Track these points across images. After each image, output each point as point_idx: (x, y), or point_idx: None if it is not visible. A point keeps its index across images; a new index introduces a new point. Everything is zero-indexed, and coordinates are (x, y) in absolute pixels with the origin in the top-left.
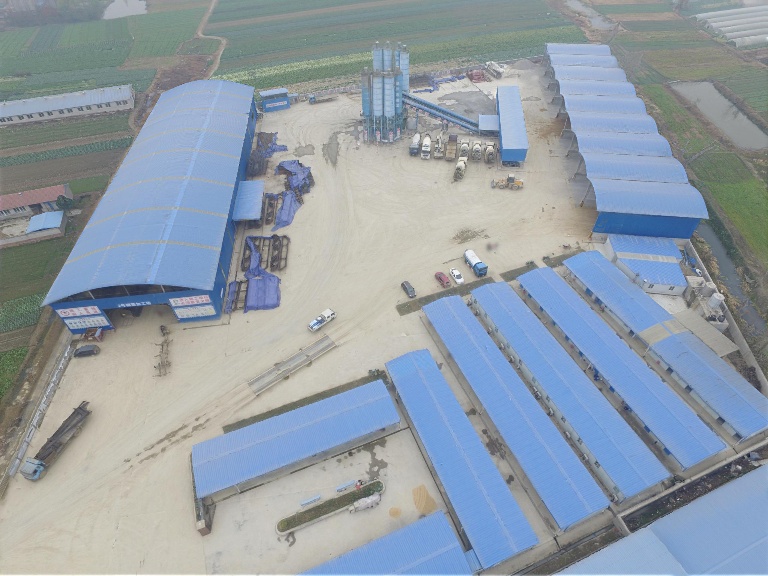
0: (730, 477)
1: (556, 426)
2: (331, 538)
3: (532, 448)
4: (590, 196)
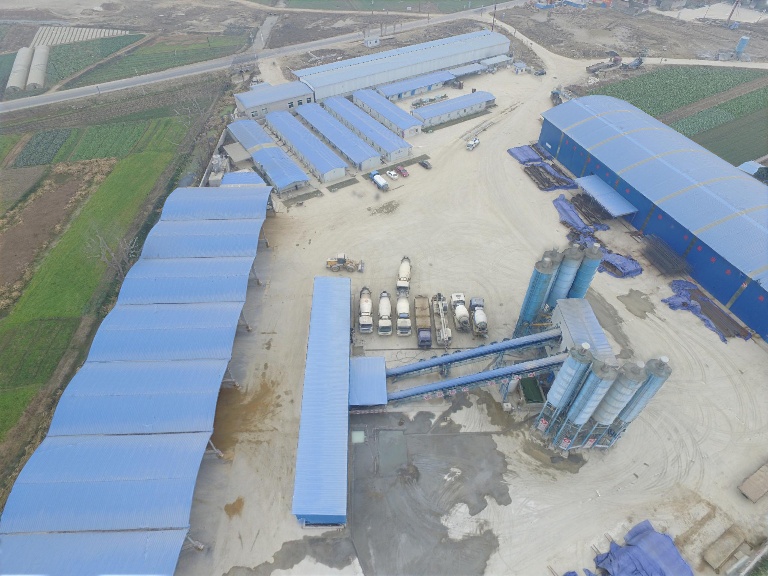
0: None
1: None
2: None
3: None
4: None
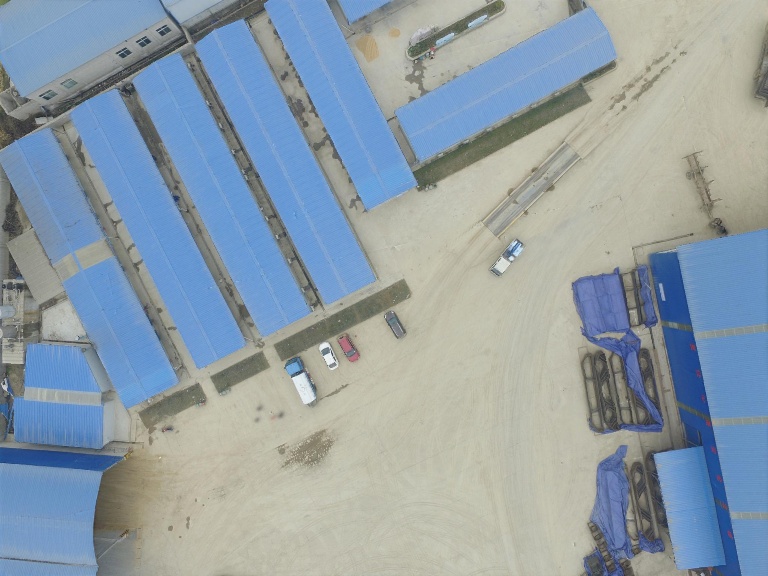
0: (80, 102)
1: (231, 138)
2: (452, 4)
3: (258, 91)
4: (108, 563)
